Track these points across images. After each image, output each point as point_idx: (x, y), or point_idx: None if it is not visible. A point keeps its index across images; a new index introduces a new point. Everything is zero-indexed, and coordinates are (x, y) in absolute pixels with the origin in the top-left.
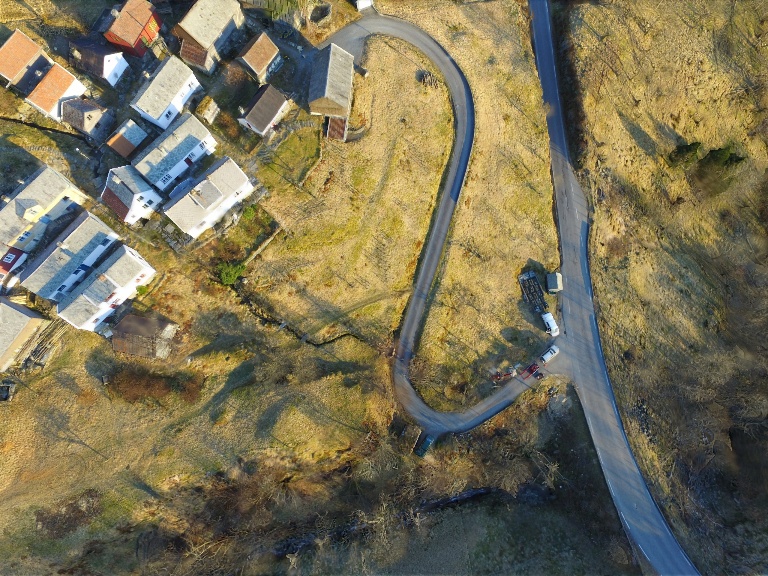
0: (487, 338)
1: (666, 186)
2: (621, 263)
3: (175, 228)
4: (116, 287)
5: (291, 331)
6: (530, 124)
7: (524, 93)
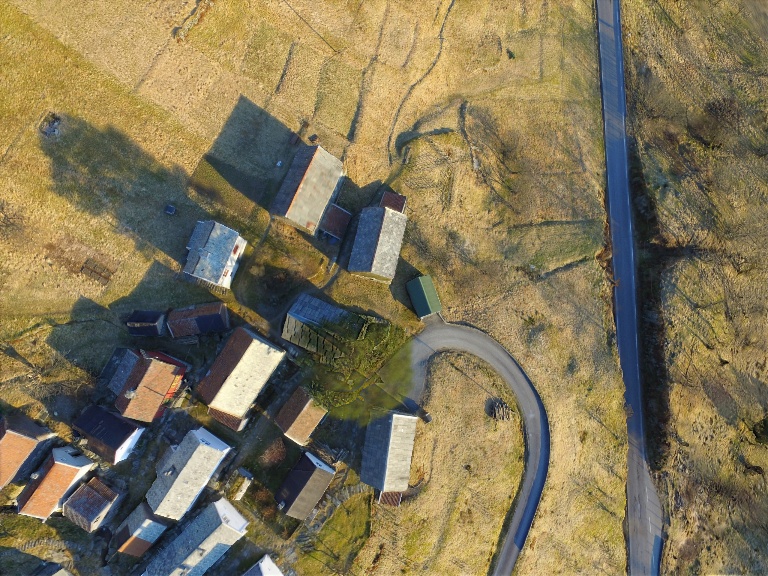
0: None
1: (743, 451)
2: (692, 570)
3: None
4: None
5: None
6: (609, 436)
7: (605, 401)
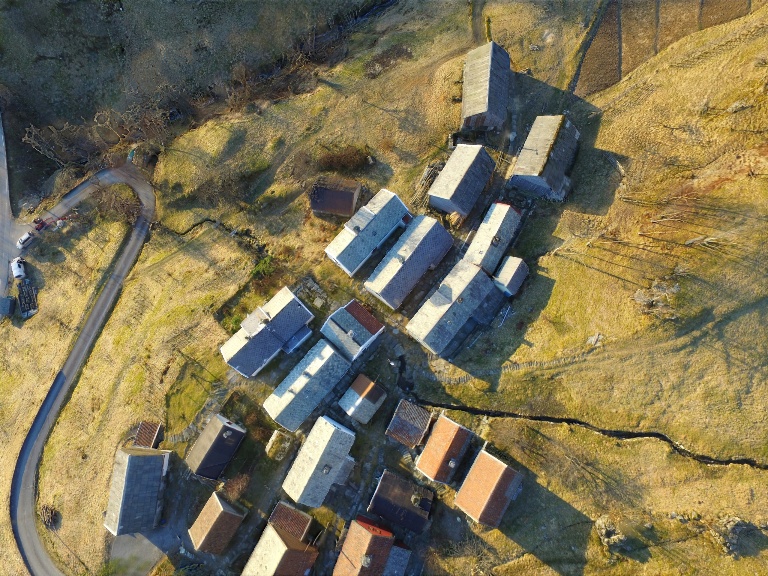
0: (77, 252)
1: None
2: None
3: (313, 303)
4: (346, 225)
5: (228, 229)
6: None
7: None
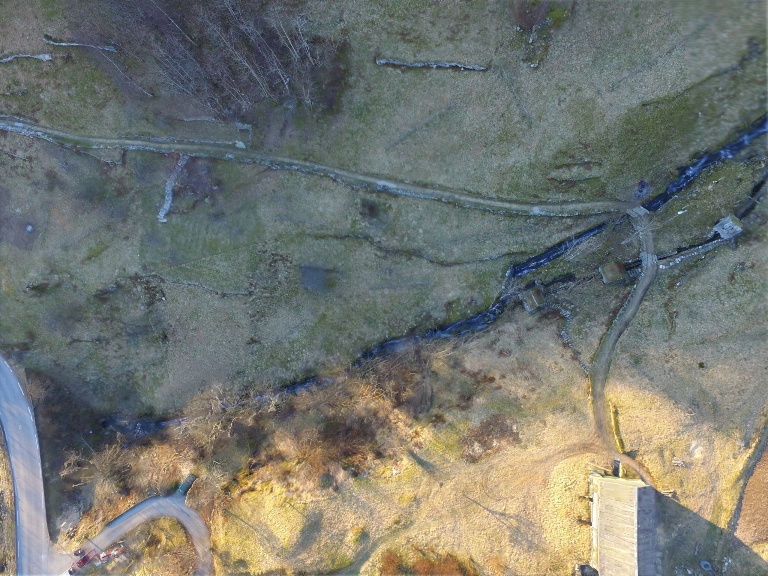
0: None
1: None
2: None
3: None
4: None
5: None
6: None
7: None
